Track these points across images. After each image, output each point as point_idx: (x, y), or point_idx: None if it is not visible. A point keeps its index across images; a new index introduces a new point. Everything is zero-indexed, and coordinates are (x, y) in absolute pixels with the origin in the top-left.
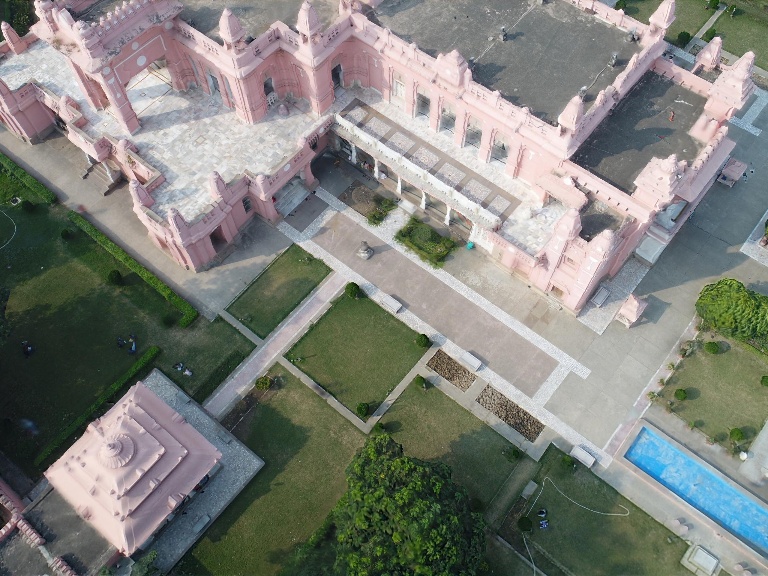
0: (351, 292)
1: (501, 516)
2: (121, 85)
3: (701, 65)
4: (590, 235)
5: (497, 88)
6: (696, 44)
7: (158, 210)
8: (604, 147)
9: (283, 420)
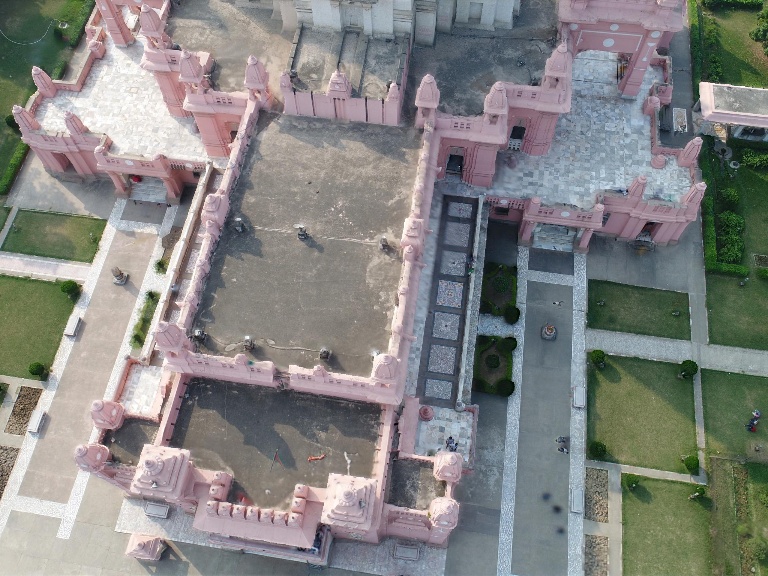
0: (62, 286)
1: None
2: (112, 2)
3: (433, 462)
4: (116, 442)
5: (228, 262)
6: (608, 471)
7: (46, 104)
8: (231, 404)
9: None
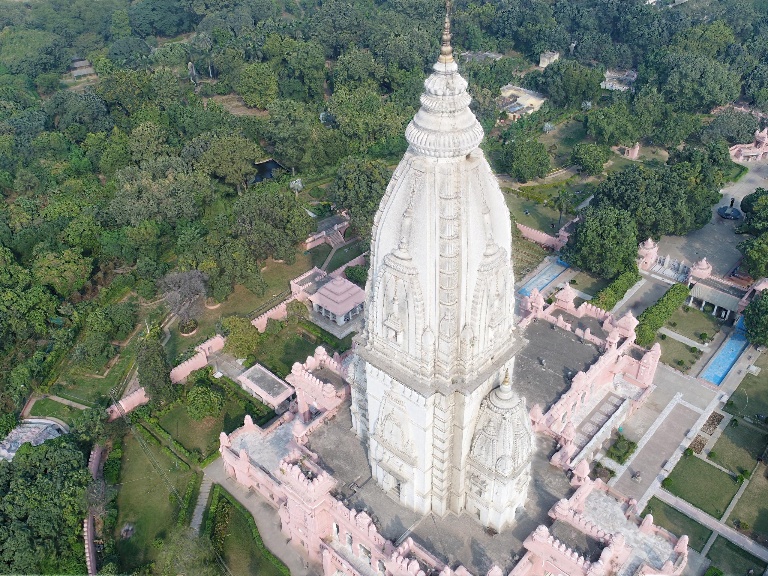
0: None
1: (766, 431)
2: None
3: (530, 309)
4: None
5: (581, 370)
6: None
7: None
8: None
9: (759, 520)
